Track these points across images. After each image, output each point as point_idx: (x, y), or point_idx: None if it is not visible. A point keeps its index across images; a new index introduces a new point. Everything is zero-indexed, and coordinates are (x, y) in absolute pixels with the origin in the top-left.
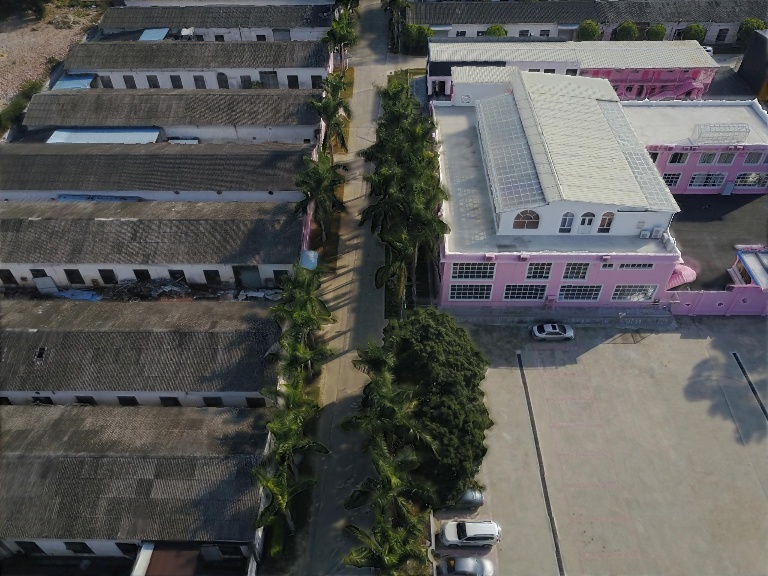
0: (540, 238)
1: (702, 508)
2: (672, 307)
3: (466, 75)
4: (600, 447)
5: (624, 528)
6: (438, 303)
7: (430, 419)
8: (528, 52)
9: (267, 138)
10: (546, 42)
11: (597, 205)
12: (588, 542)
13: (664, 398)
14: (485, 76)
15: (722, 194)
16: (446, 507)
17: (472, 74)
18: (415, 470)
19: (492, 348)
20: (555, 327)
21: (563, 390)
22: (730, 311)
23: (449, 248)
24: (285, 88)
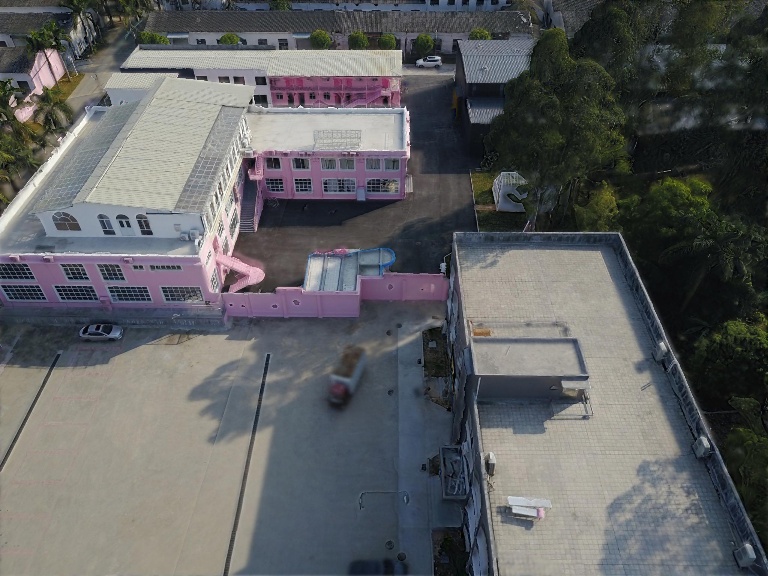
0: (84, 240)
1: (128, 505)
2: (228, 309)
3: (122, 81)
4: (72, 445)
5: (39, 524)
6: (2, 304)
7: None
8: (224, 60)
9: None
10: (253, 50)
11: (120, 207)
12: None
13: (167, 397)
14: (139, 82)
15: (357, 199)
16: None
17: (128, 80)
18: None
19: (36, 348)
20: (99, 327)
21: (76, 389)
22: (287, 313)
23: None
24: None
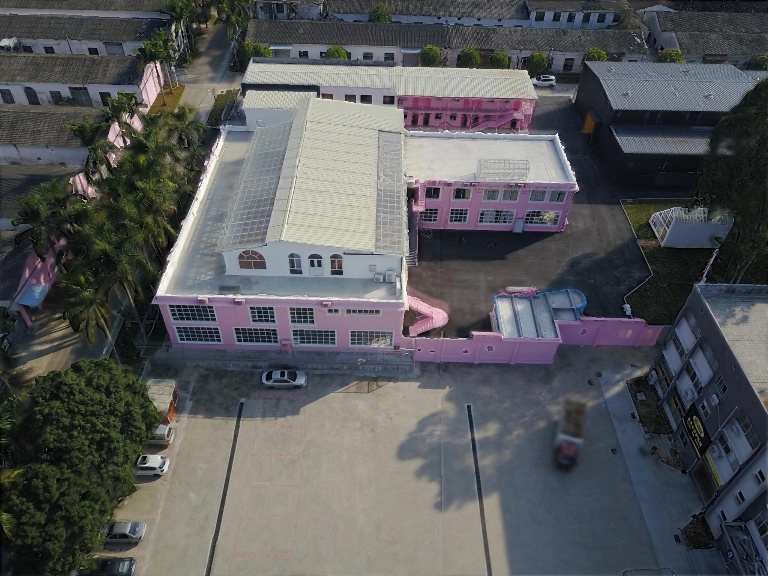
0: (269, 279)
1: None
2: (416, 354)
3: (259, 100)
4: (287, 510)
5: None
6: (170, 345)
7: (19, 492)
8: (348, 76)
9: (52, 159)
10: (373, 66)
11: (318, 247)
12: None
13: (376, 455)
14: (278, 101)
15: (513, 231)
16: None
17: (266, 99)
18: (4, 549)
19: (215, 395)
20: (284, 374)
21: (273, 444)
22: (477, 359)
23: (167, 288)
24: (99, 105)
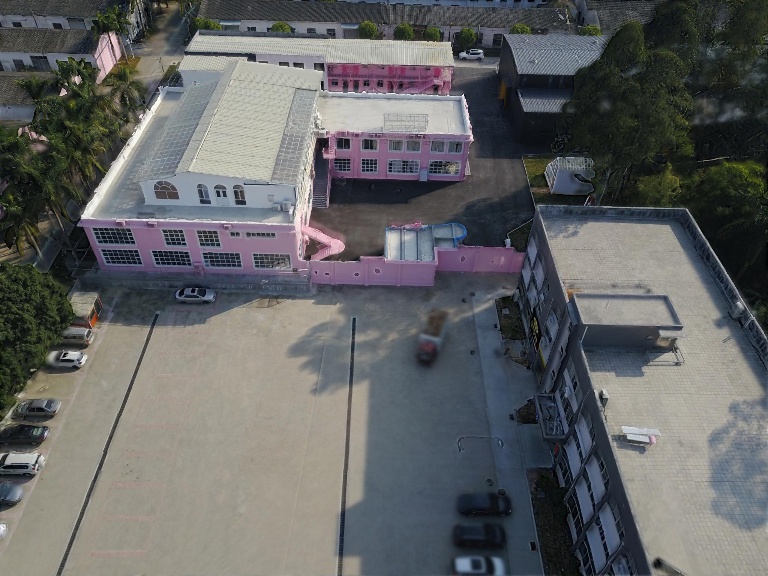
0: (182, 208)
1: (244, 446)
2: (313, 276)
3: (194, 63)
4: (183, 394)
5: (165, 462)
6: (98, 267)
7: None
8: (283, 46)
9: (10, 117)
10: (309, 38)
11: (221, 177)
12: (125, 473)
13: (266, 354)
14: (211, 65)
15: (419, 180)
16: (7, 442)
17: (200, 62)
18: None
19: (135, 309)
20: (194, 291)
21: (179, 346)
22: (367, 281)
23: (92, 214)
24: None
